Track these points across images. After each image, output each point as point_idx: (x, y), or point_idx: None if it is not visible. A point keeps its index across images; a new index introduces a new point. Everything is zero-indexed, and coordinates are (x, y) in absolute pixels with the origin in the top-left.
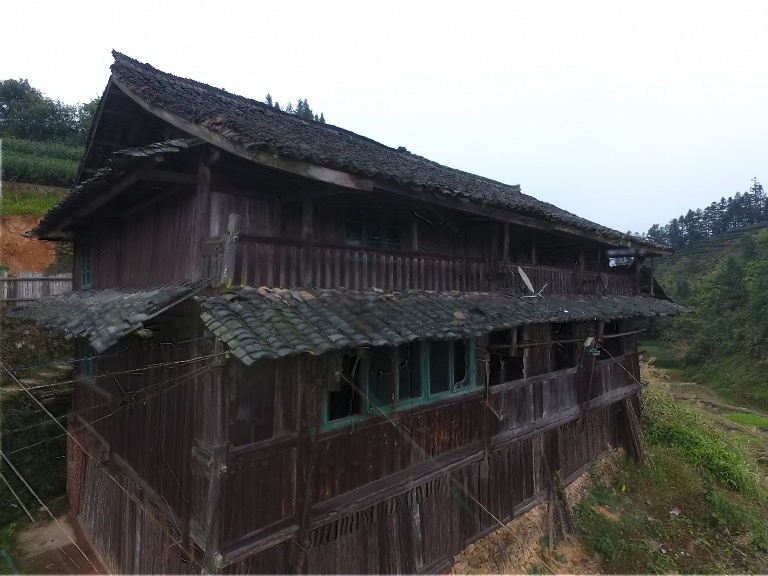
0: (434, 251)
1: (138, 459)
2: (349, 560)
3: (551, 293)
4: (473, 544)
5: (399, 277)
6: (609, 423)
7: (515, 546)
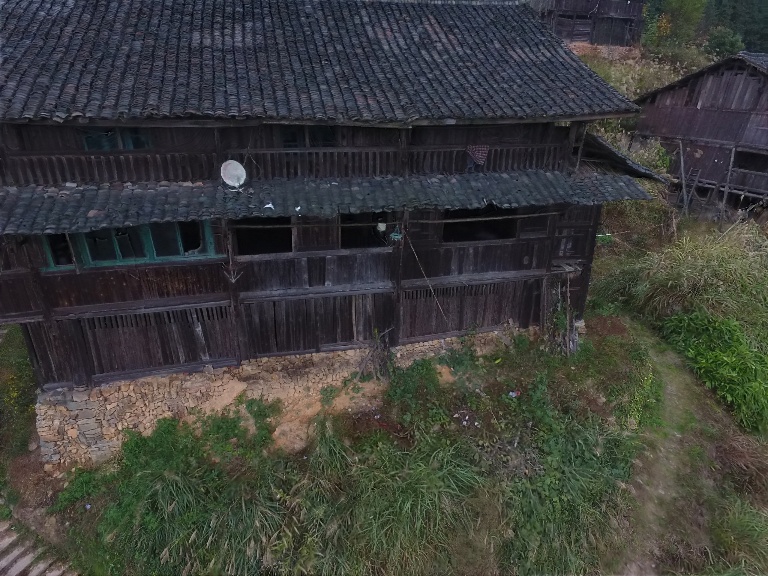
0: (150, 146)
1: None
2: (133, 341)
3: (339, 175)
4: (267, 358)
5: (105, 171)
6: (518, 301)
7: (316, 369)
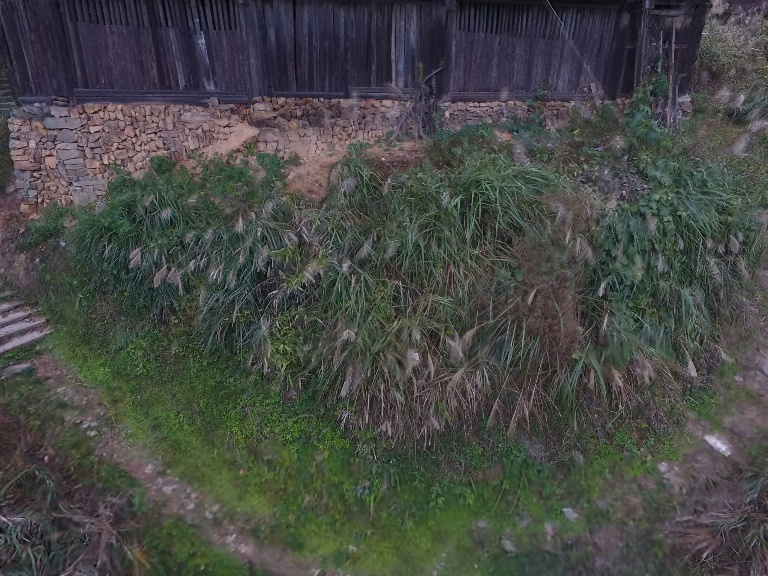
0: None
1: None
2: (122, 46)
3: None
4: (284, 98)
5: None
6: (605, 57)
7: (343, 121)
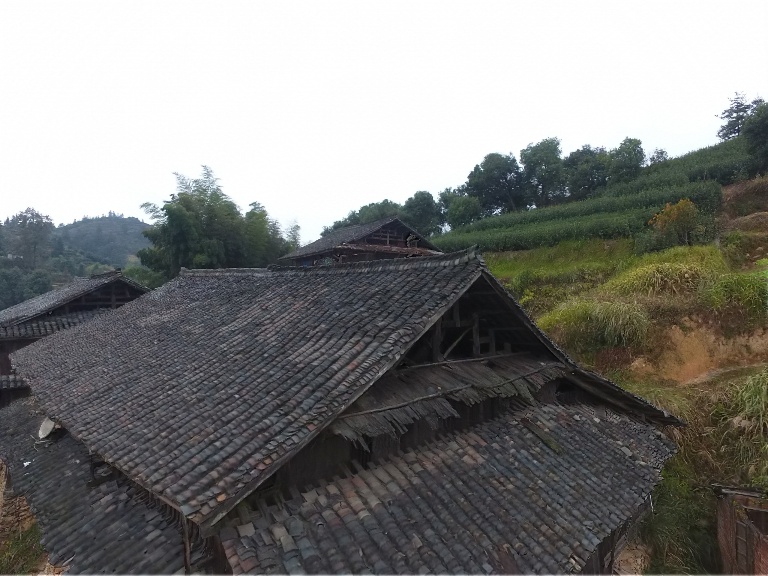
0: None
1: None
2: None
3: None
4: None
5: None
6: None
7: None
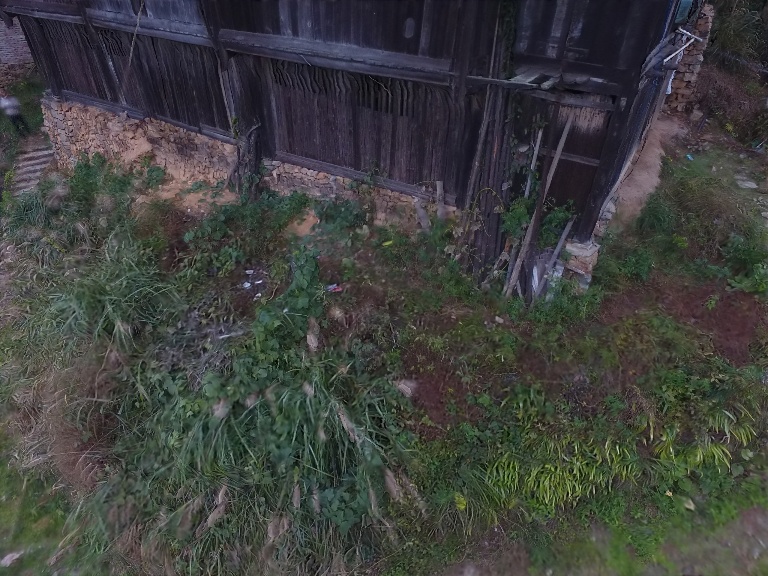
0: None
1: None
2: None
3: None
4: (164, 122)
5: None
6: (456, 149)
7: (199, 155)
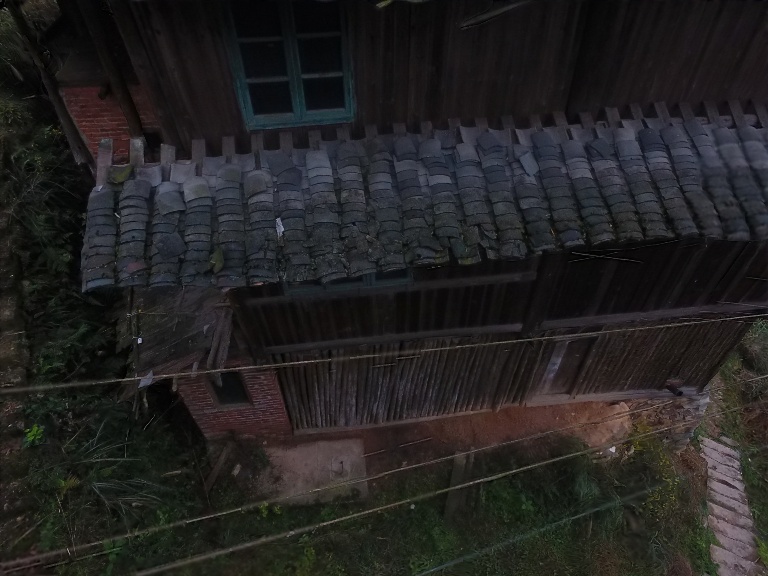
0: None
1: (641, 301)
2: None
3: None
4: None
5: None
6: None
7: None
